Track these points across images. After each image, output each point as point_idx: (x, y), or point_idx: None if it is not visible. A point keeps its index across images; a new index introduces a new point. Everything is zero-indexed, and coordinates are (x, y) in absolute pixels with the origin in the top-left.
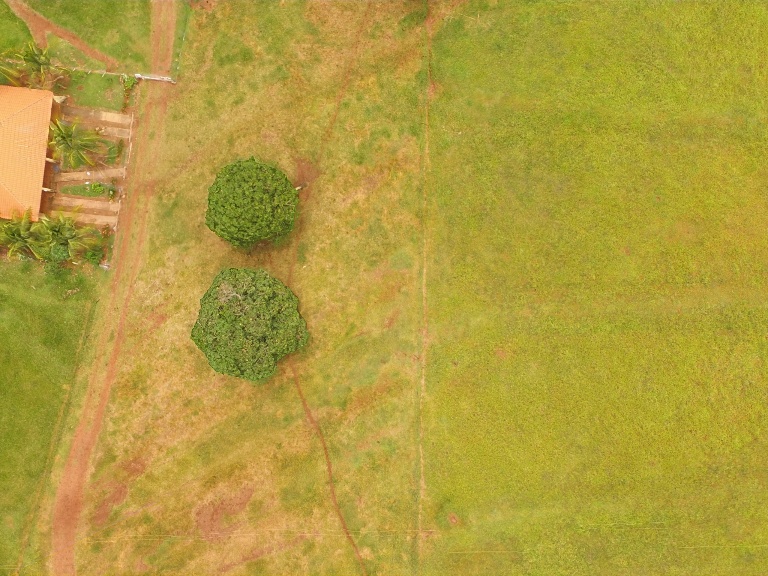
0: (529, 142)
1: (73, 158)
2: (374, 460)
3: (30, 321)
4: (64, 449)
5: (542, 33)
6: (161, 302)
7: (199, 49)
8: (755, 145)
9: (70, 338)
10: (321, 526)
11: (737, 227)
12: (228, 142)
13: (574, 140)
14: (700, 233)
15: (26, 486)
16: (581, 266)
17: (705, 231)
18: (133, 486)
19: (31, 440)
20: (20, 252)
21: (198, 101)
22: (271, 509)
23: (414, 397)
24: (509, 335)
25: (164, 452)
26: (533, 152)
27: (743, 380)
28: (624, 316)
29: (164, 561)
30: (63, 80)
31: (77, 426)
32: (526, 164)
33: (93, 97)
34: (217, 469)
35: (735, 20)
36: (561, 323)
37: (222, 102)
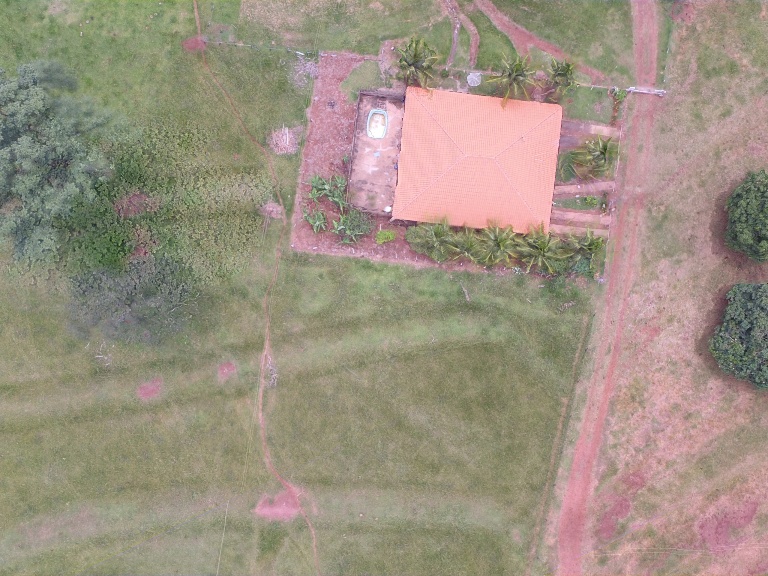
0: None
1: (564, 171)
2: None
3: (527, 334)
4: (566, 462)
5: None
6: (654, 315)
7: (684, 62)
8: None
9: (567, 351)
10: None
11: None
12: (715, 155)
13: None
14: None
15: (529, 499)
16: None
17: None
18: (635, 499)
19: (532, 453)
20: (520, 266)
21: (684, 114)
22: None
23: None
24: None
25: (663, 465)
26: None
27: None
28: None
29: (671, 574)
30: (554, 93)
31: (578, 439)
32: None
33: (583, 110)
34: (720, 482)
35: None
36: None
37: (709, 115)
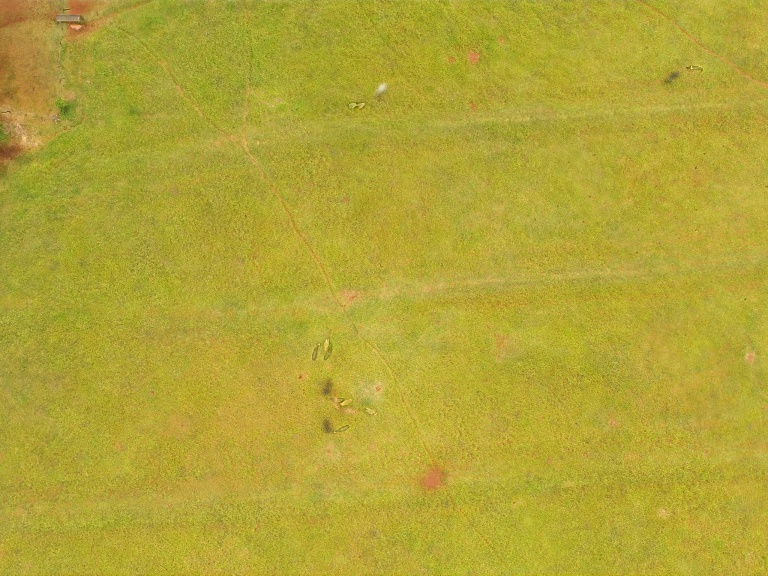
0: (24, 340)
1: None
2: None
3: None
4: None
5: (38, 230)
6: None
7: None
8: (246, 337)
9: None
10: None
11: (230, 419)
12: None
13: (68, 337)
14: (194, 426)
15: None
16: (75, 463)
17: (199, 423)
18: None
19: None
20: None
21: None
22: None
23: None
24: (3, 535)
25: None
26: (29, 350)
27: (231, 573)
28: (115, 513)
29: None
30: None
31: None
32: (21, 362)
33: None
34: None
35: (229, 211)
36: (53, 522)
37: None
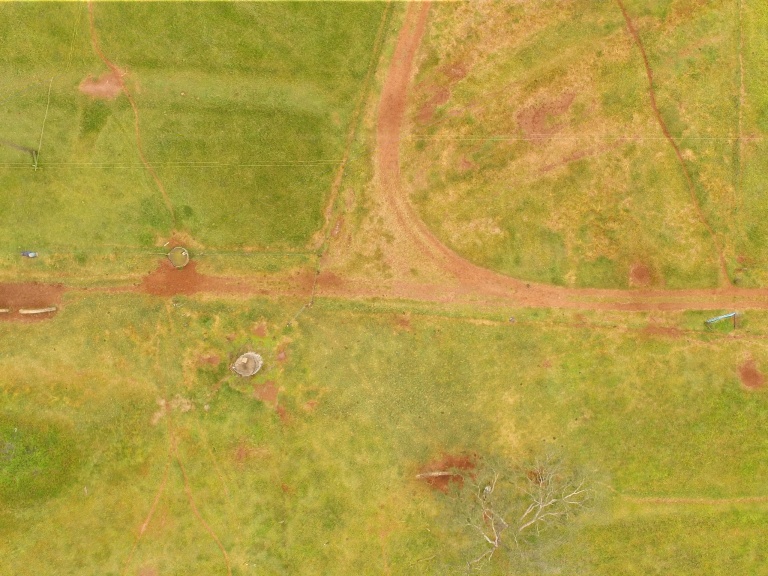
0: None
1: None
2: (694, 68)
3: None
4: (388, 50)
5: None
6: None
7: None
8: None
9: None
10: (641, 131)
11: None
12: None
13: None
14: None
15: (350, 85)
16: None
17: None
18: (455, 88)
19: (355, 42)
20: None
21: None
22: (592, 113)
23: (734, 8)
24: None
25: (484, 58)
26: None
27: None
28: None
29: (487, 160)
30: None
31: (400, 29)
32: None
33: None
34: (539, 73)
35: None
36: None
37: None
